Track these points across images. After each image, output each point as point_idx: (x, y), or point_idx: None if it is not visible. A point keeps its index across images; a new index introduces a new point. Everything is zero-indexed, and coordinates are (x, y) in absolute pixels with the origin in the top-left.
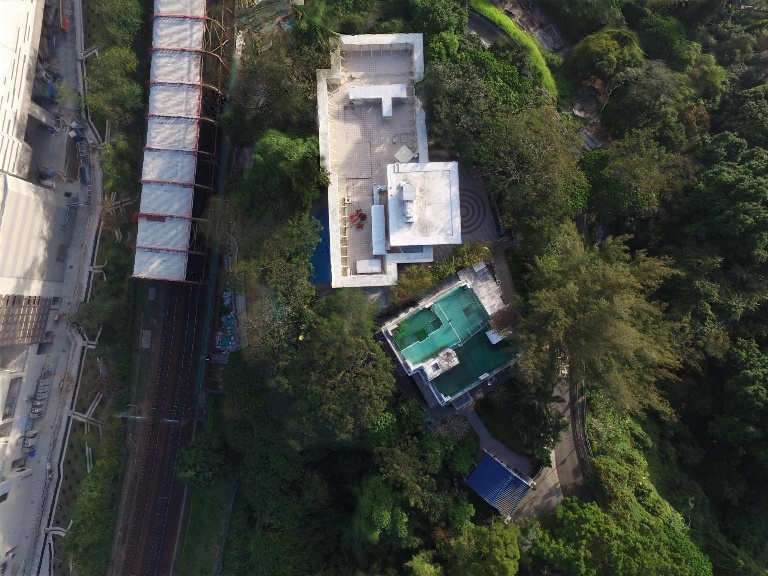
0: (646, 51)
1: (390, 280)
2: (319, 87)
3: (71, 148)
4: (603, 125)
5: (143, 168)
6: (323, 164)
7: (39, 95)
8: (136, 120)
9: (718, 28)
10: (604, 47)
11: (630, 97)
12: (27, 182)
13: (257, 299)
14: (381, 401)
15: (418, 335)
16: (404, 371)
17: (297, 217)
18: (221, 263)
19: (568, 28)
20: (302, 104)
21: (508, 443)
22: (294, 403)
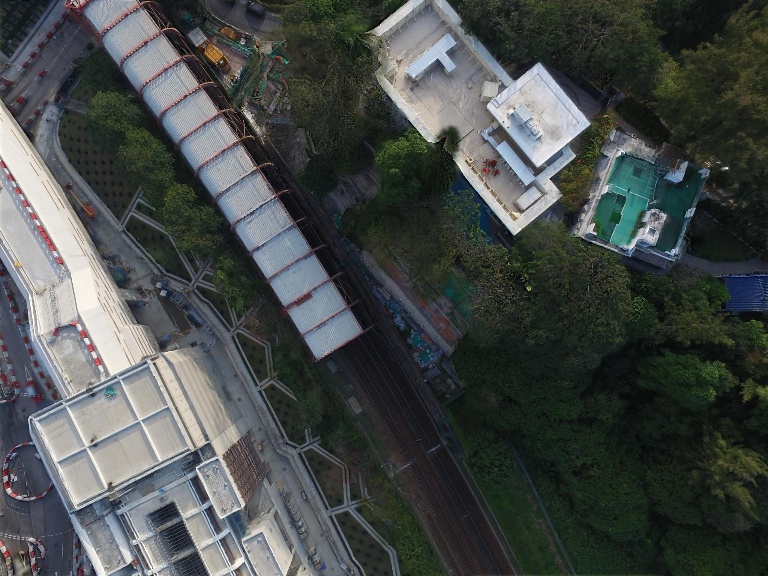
0: None
1: (554, 196)
2: (384, 86)
3: (168, 306)
4: None
5: (262, 268)
6: None
7: (117, 281)
8: (223, 236)
9: None
10: None
11: None
12: (174, 351)
13: (428, 304)
14: (626, 292)
15: (613, 220)
16: (624, 256)
17: (448, 200)
18: (376, 298)
19: None
20: (381, 110)
21: (731, 257)
22: (560, 344)
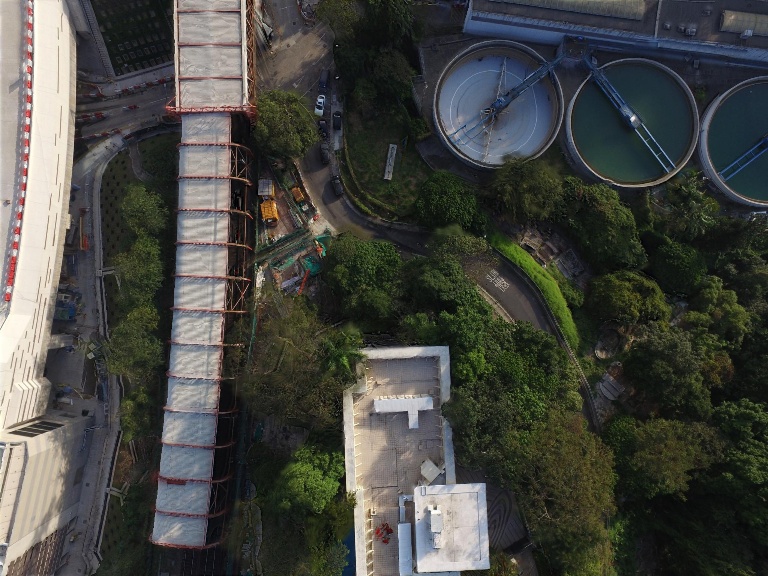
0: (667, 282)
1: None
2: (345, 403)
3: (89, 365)
4: (626, 375)
5: (164, 428)
6: (349, 486)
7: (58, 323)
8: (156, 373)
9: (739, 256)
10: (627, 302)
11: (655, 368)
12: (46, 433)
13: None
14: None
15: None
16: None
17: (323, 543)
18: (241, 518)
19: (588, 255)
20: (328, 421)
21: None
22: None
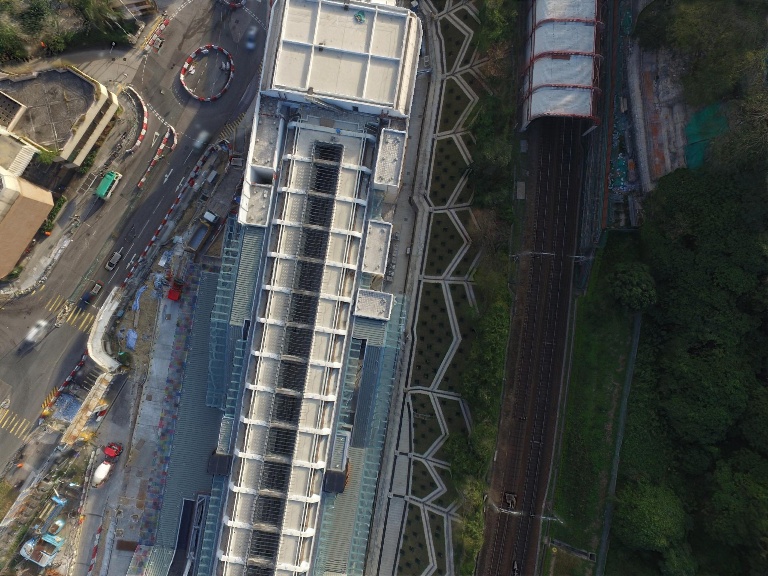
0: None
1: None
2: None
3: None
4: None
5: (543, 9)
6: None
7: None
8: None
9: None
10: None
11: None
12: None
13: (658, 134)
14: None
15: None
16: None
17: None
18: None
19: None
20: None
21: None
22: None
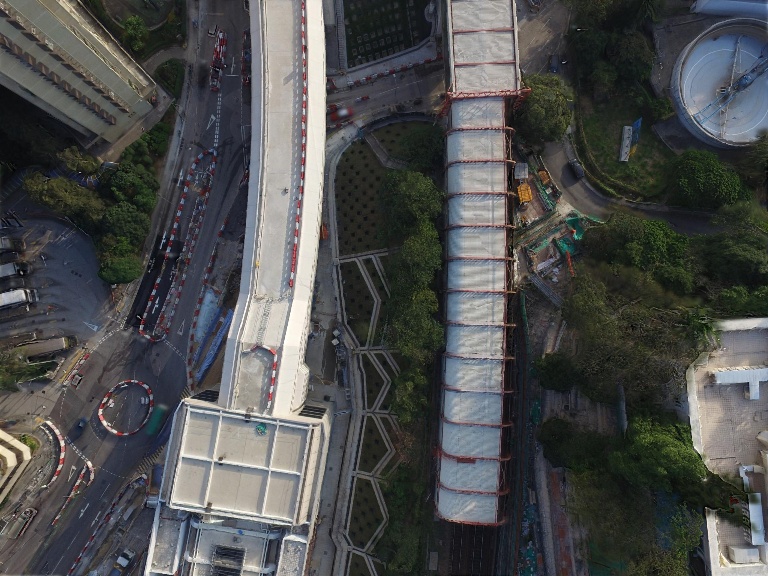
0: None
1: None
2: (688, 375)
3: (328, 351)
4: None
5: (449, 408)
6: (701, 456)
7: None
8: (433, 354)
9: None
10: None
11: None
12: (325, 416)
13: (565, 537)
14: None
15: None
16: None
17: (680, 513)
18: (522, 496)
19: None
20: (673, 393)
21: None
22: None
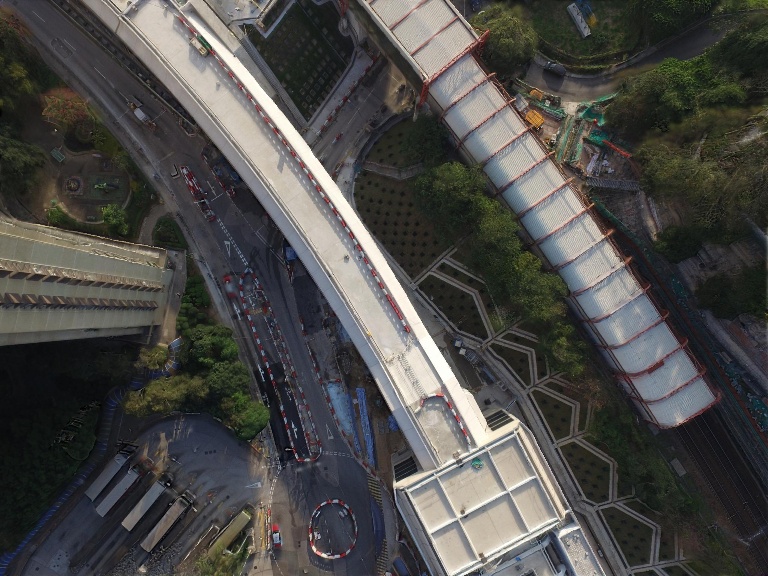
0: None
1: None
2: None
3: (460, 364)
4: None
5: (610, 335)
6: None
7: None
8: None
9: None
10: None
11: None
12: None
13: None
14: None
15: None
16: None
17: None
18: None
19: None
20: None
21: None
22: None
